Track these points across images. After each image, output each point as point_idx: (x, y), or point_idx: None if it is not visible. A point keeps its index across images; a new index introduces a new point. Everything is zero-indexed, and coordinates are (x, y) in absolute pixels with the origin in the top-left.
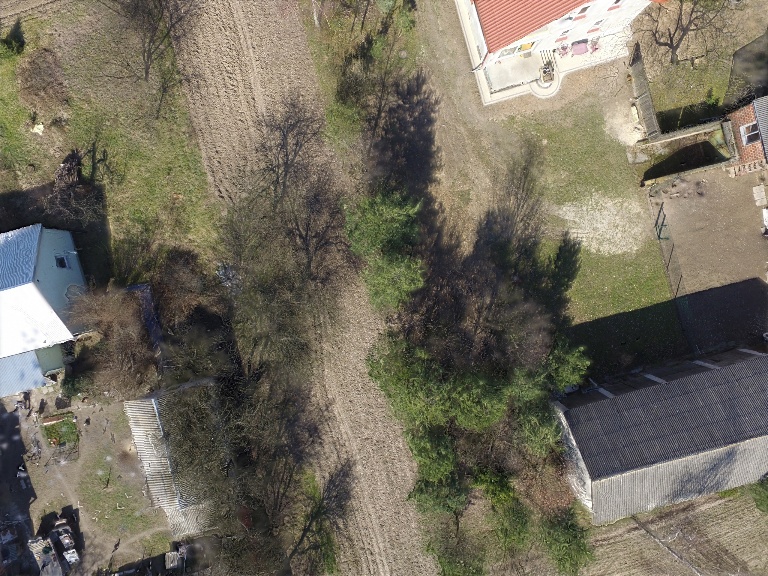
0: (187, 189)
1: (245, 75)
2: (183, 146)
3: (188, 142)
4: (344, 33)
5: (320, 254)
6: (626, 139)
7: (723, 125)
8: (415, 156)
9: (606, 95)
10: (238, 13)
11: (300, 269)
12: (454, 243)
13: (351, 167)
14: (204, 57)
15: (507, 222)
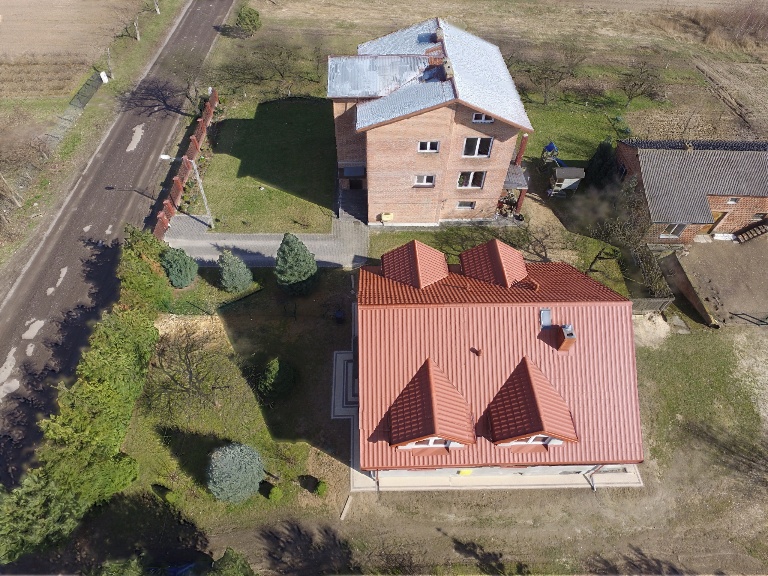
0: None
1: None
2: None
3: None
4: None
5: None
6: (663, 331)
7: None
8: None
9: None
10: None
11: None
12: None
13: None
14: None
15: None
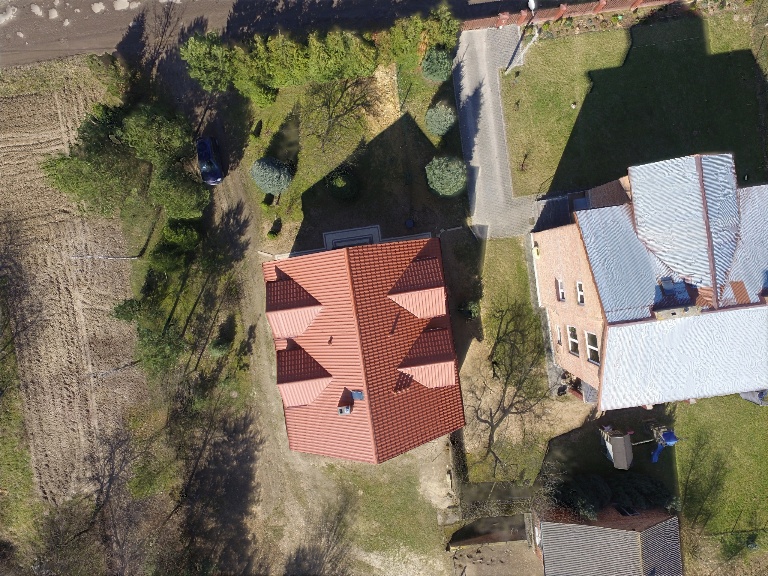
0: (13, 486)
1: (82, 387)
2: (14, 446)
3: (19, 444)
4: (180, 366)
5: (134, 564)
6: (438, 502)
7: (524, 515)
8: (235, 488)
9: (424, 459)
10: (82, 330)
11: (113, 574)
12: (262, 574)
13: (172, 489)
14: (44, 366)
15: (315, 561)
